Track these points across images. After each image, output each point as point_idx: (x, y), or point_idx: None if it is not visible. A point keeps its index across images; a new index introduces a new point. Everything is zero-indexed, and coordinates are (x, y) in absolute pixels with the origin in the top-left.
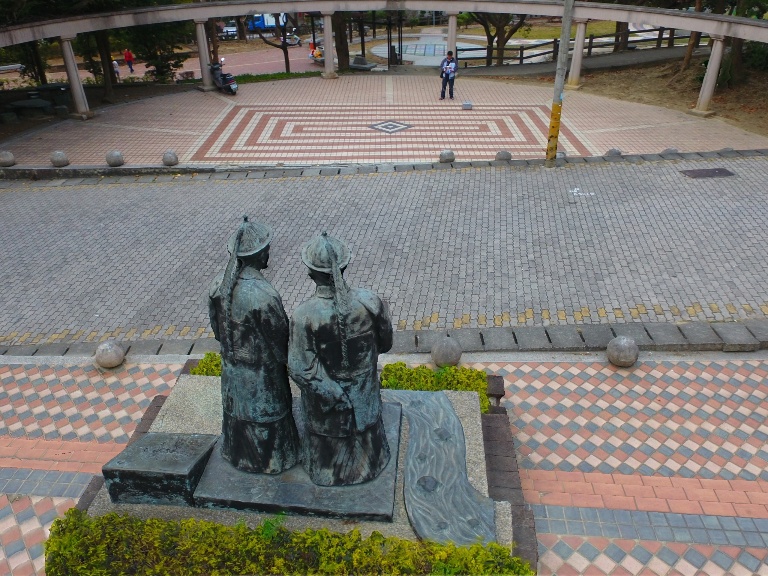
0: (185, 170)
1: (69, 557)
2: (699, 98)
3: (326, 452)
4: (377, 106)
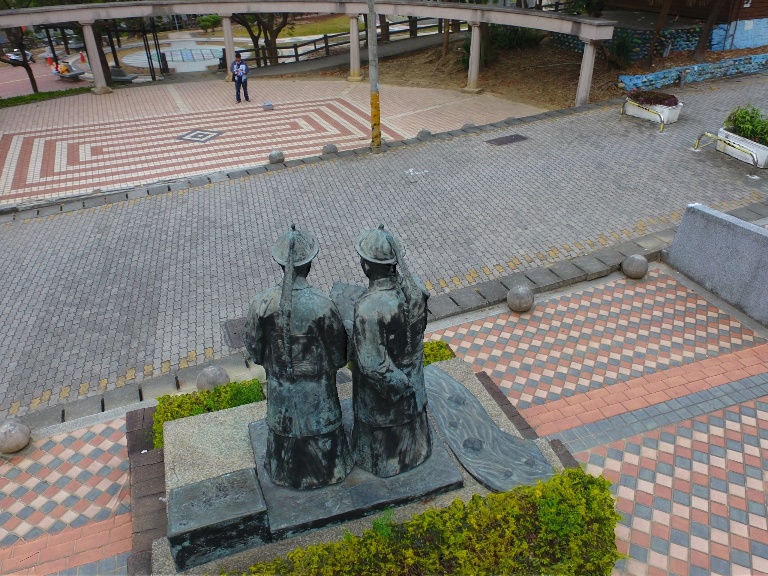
0: None
1: None
2: (469, 78)
3: (391, 443)
4: (174, 117)
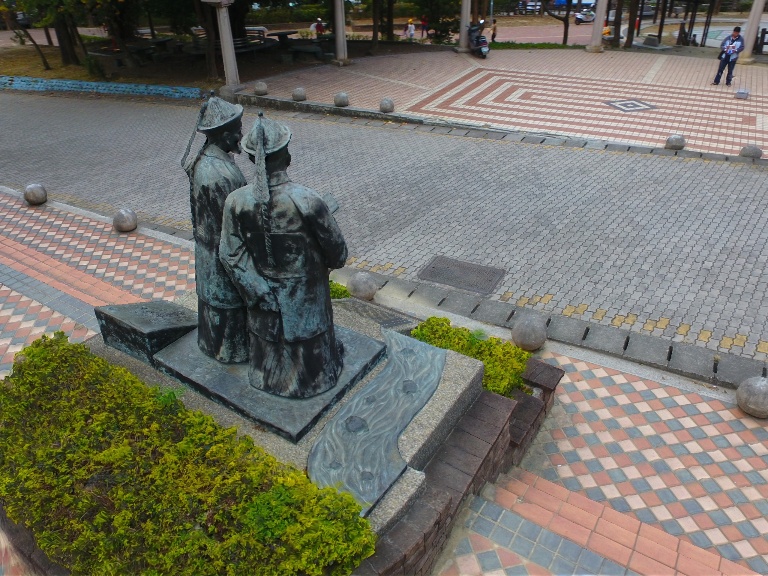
0: (397, 118)
1: (27, 362)
2: None
3: (259, 353)
4: (628, 83)
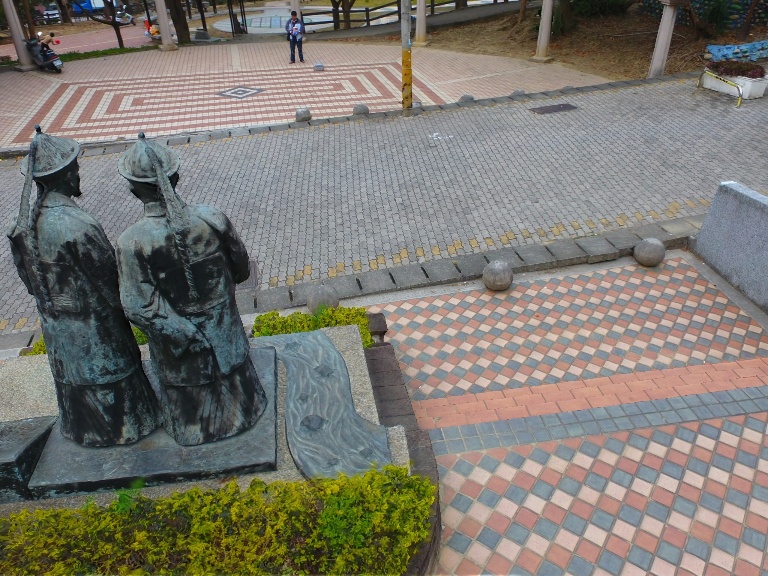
0: (6, 154)
1: None
2: (538, 45)
3: (188, 406)
4: (224, 74)
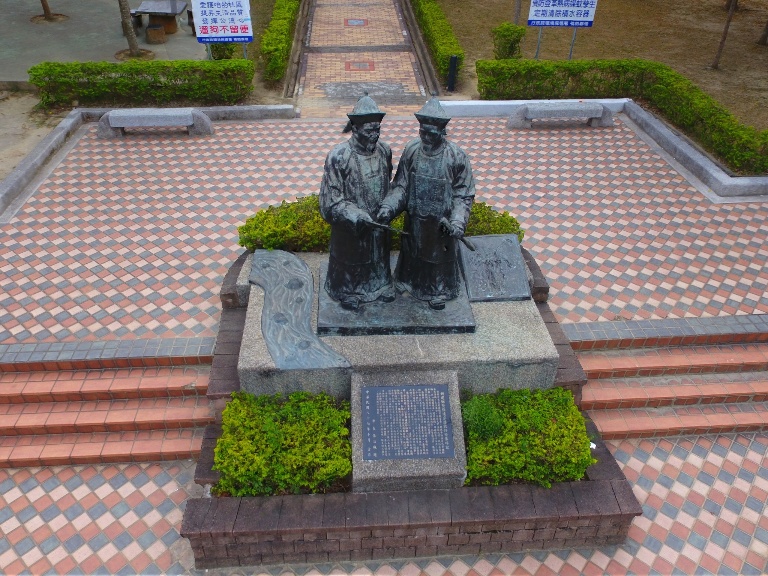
0: None
1: (494, 212)
2: None
3: None
4: None
